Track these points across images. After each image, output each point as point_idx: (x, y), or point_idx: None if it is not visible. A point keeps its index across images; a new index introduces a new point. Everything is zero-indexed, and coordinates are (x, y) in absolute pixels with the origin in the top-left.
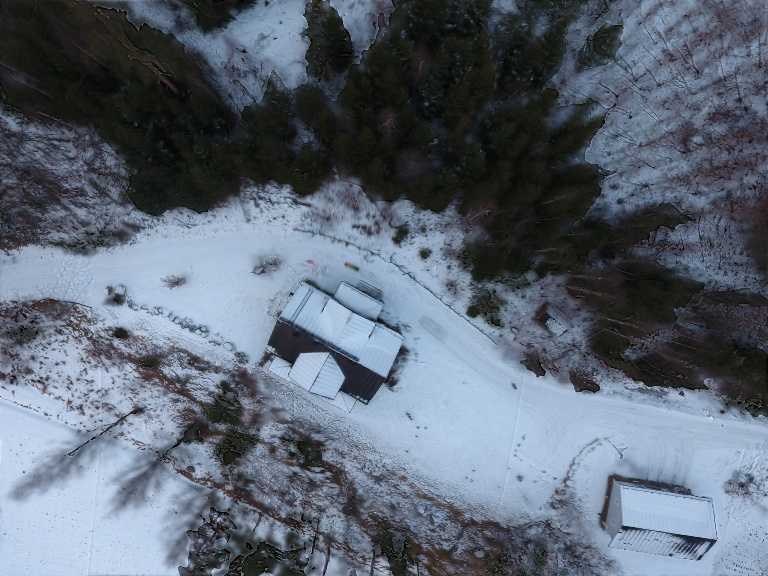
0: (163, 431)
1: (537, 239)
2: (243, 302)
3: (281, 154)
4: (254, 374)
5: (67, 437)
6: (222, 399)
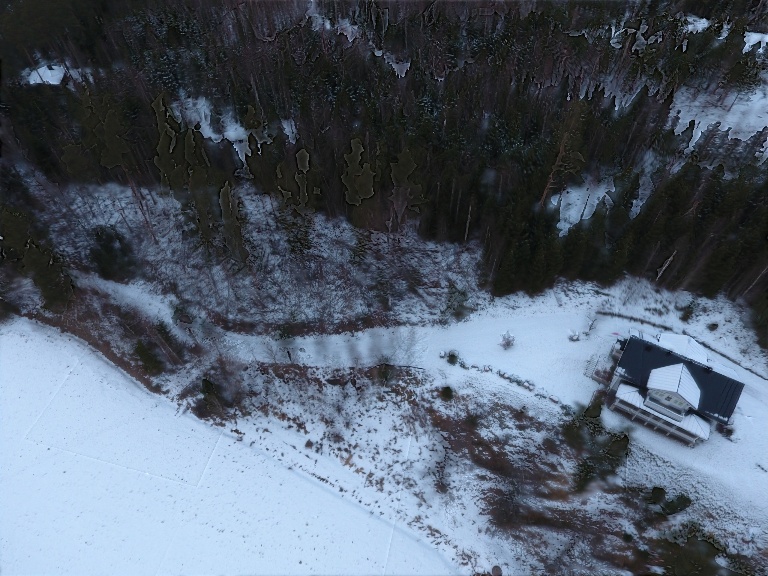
0: (464, 518)
1: None
2: (563, 363)
3: None
4: (581, 427)
5: (359, 518)
6: (544, 462)
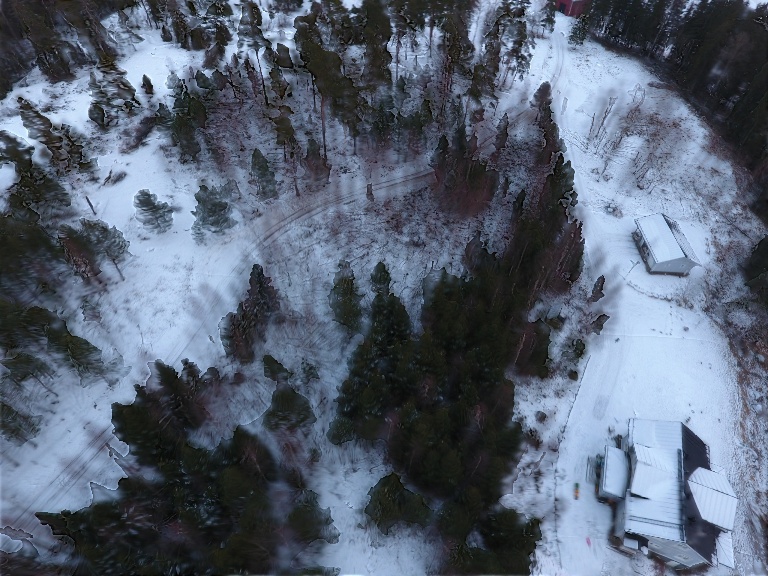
0: None
1: (520, 315)
2: None
3: None
4: None
5: None
6: None
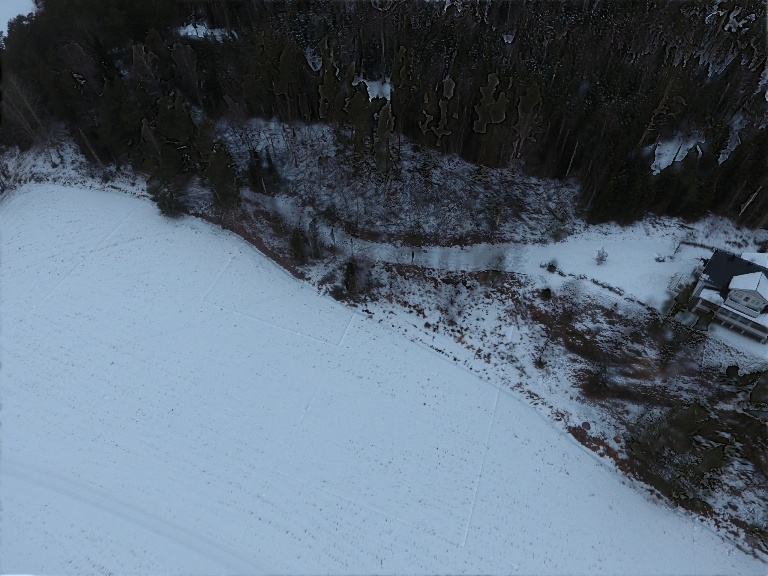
0: (558, 388)
1: None
2: (649, 277)
3: (694, 182)
4: (665, 324)
5: (470, 380)
6: (630, 349)
